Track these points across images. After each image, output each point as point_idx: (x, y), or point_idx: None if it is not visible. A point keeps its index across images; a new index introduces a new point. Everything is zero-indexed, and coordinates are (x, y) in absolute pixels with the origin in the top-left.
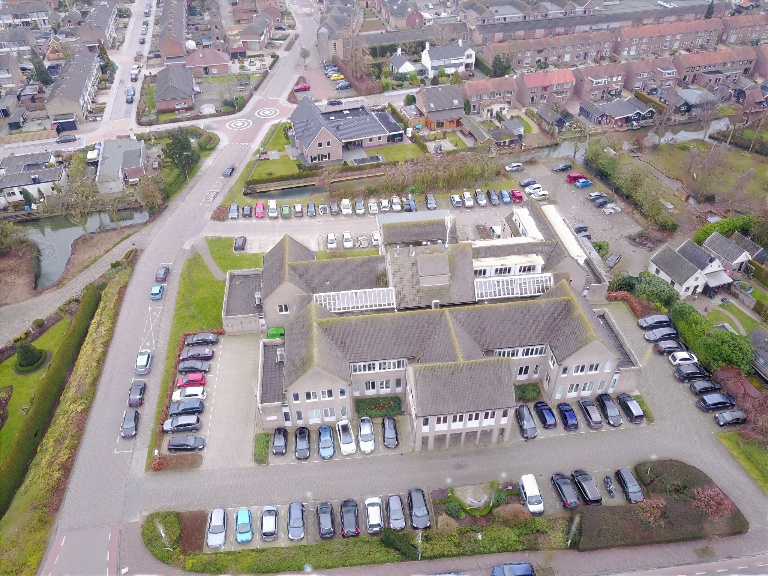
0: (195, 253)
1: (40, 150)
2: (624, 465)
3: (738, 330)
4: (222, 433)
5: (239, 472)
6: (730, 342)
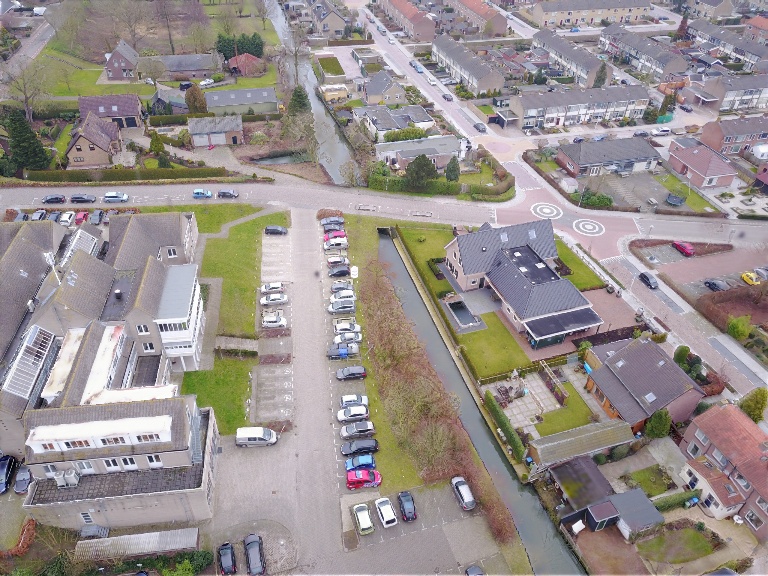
0: (260, 207)
1: (460, 122)
2: None
3: None
4: None
5: None
6: None
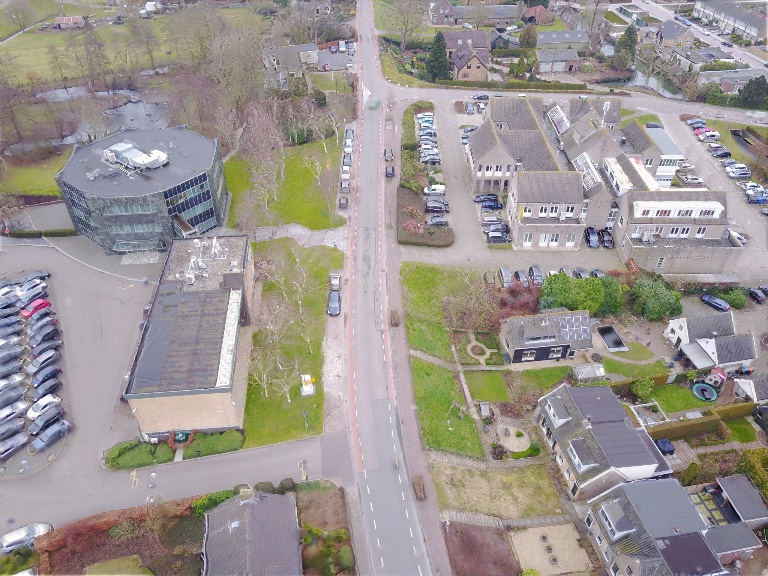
0: (633, 111)
1: (749, 62)
2: (454, 227)
3: (621, 356)
4: (478, 119)
5: (455, 123)
6: (558, 280)
